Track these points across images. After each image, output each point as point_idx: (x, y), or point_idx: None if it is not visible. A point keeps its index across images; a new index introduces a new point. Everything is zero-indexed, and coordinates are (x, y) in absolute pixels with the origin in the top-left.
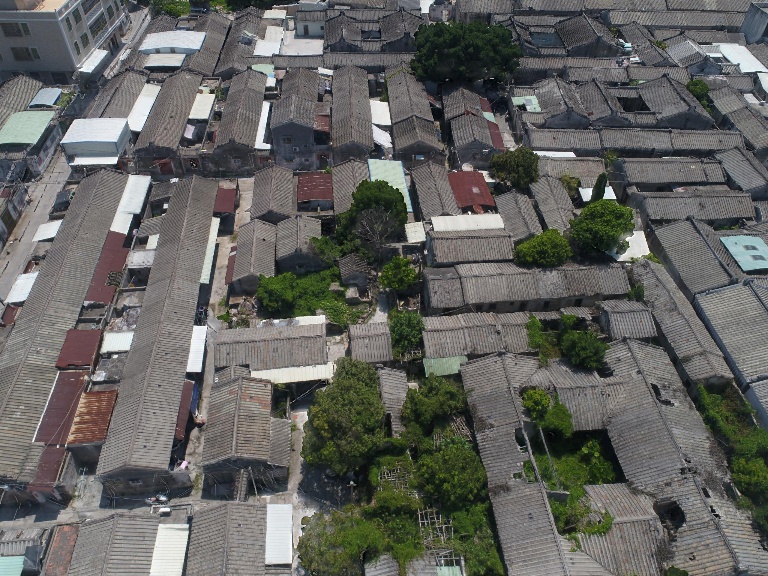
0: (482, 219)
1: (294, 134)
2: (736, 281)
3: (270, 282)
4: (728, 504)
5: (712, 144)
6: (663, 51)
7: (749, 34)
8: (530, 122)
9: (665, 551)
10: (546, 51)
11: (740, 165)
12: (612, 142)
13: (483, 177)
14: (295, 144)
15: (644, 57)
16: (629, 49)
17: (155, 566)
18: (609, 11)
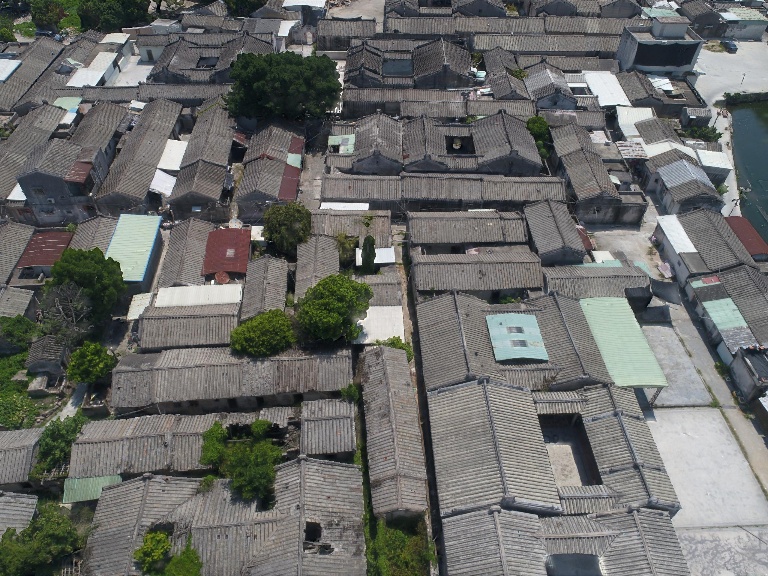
0: (217, 291)
1: (45, 185)
2: (472, 377)
3: None
4: None
5: (528, 194)
6: (520, 81)
7: (623, 61)
8: (335, 166)
9: None
10: (391, 81)
11: (545, 222)
12: (414, 192)
13: (249, 235)
14: (49, 195)
15: (495, 88)
16: (481, 79)
17: None
18: (474, 35)
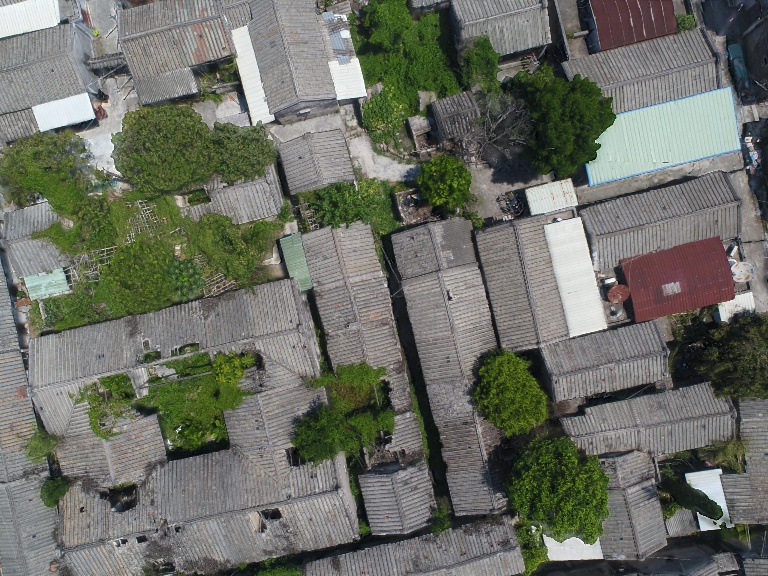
0: (586, 300)
1: None
2: None
3: (392, 3)
4: (141, 560)
5: None
6: None
7: None
8: None
9: (89, 485)
10: None
11: None
12: None
13: (720, 301)
14: None
15: None
16: None
17: (19, 6)
18: None
